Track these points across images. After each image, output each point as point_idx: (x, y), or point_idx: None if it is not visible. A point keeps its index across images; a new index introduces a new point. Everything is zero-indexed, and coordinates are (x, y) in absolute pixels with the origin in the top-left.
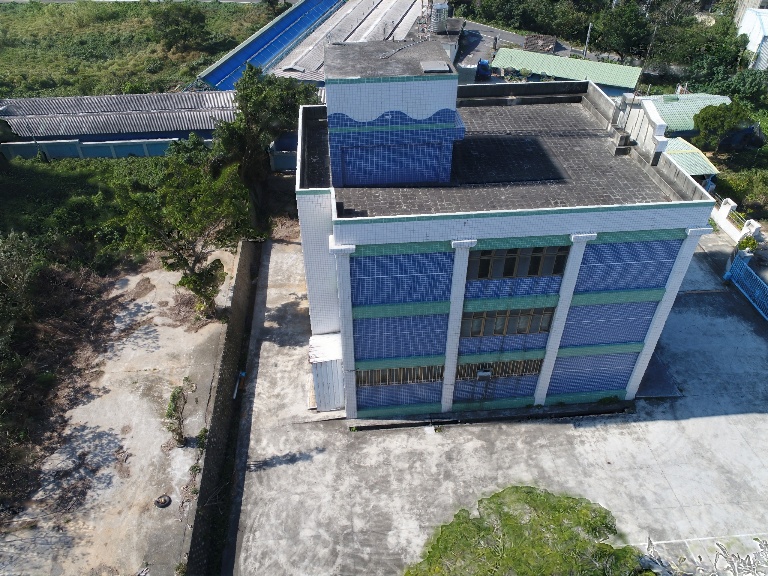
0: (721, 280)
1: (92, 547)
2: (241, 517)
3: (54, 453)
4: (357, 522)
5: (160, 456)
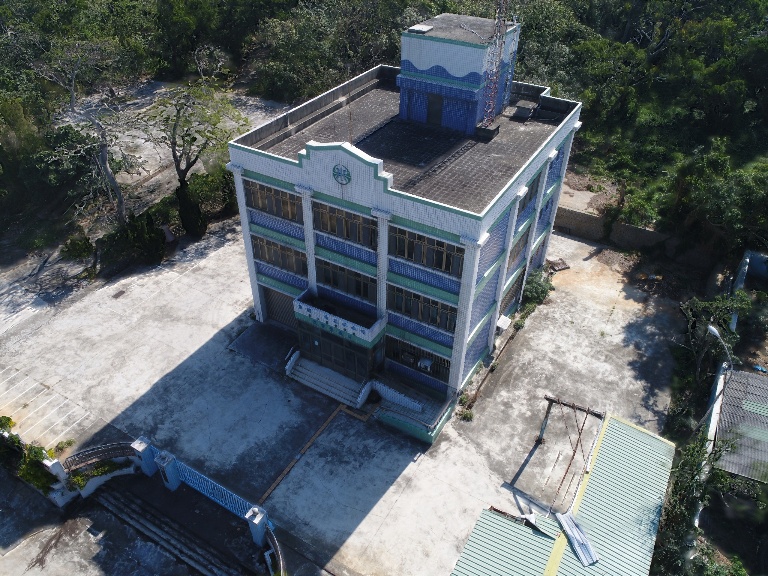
0: (273, 522)
1: None
2: None
3: None
4: None
5: None
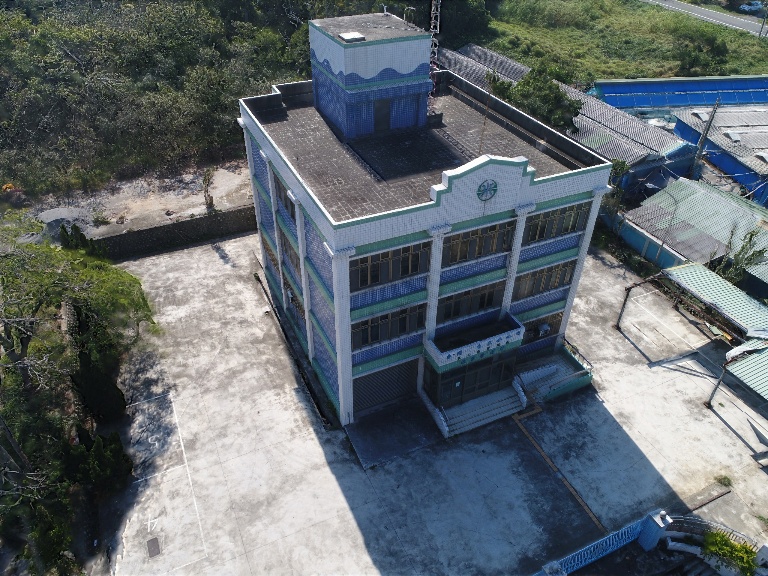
0: None
1: (140, 203)
2: (179, 251)
3: (193, 175)
4: (181, 292)
5: (199, 203)
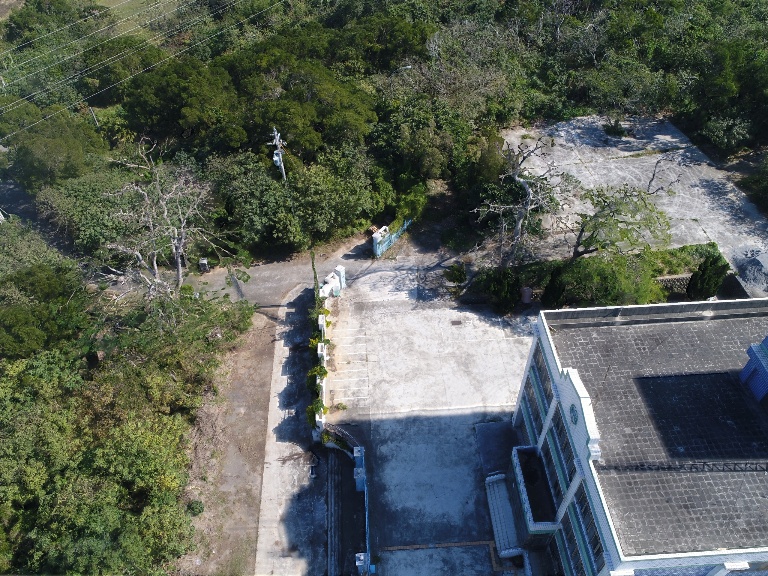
0: (379, 568)
1: None
2: None
3: None
4: None
5: None
